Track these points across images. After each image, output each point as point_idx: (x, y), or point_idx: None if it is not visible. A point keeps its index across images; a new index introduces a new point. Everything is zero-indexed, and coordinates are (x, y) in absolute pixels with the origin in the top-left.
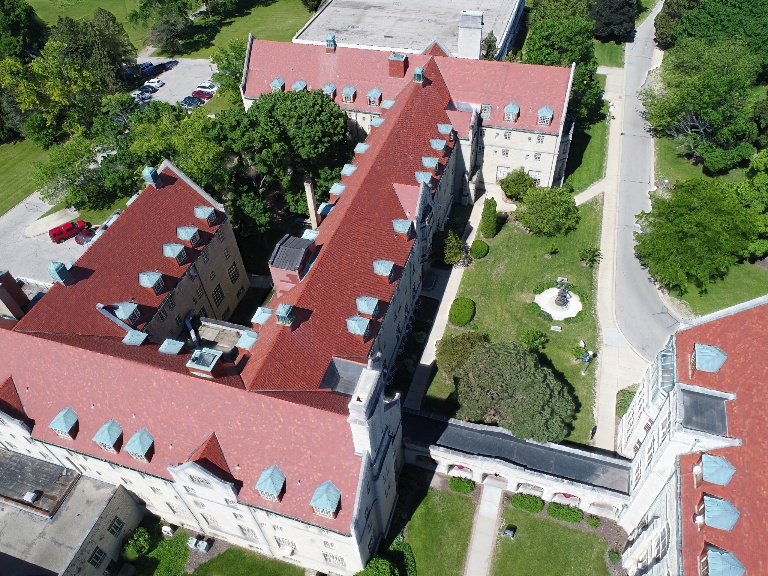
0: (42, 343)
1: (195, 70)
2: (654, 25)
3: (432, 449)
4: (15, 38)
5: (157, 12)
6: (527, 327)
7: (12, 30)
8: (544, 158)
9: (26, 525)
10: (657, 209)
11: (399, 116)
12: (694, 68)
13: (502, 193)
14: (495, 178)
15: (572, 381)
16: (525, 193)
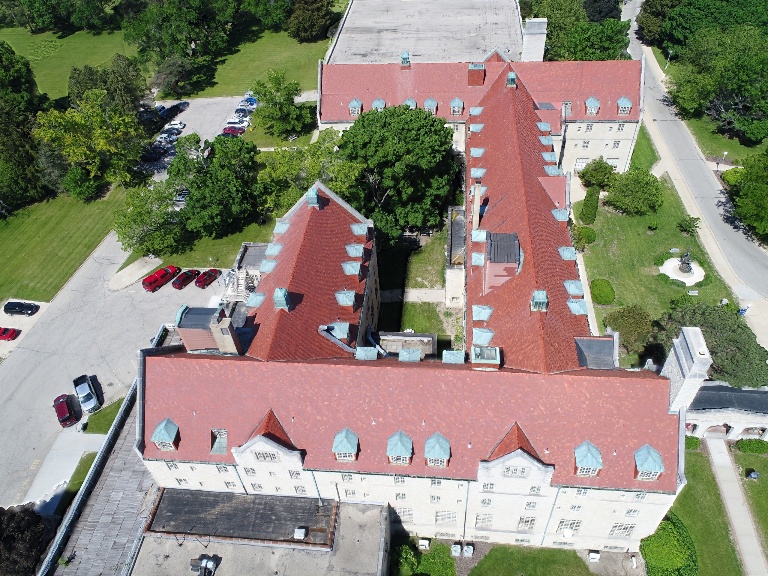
0: (305, 368)
1: (212, 108)
2: (640, 25)
3: None
4: (18, 94)
5: (159, 55)
6: (666, 296)
7: (12, 86)
8: (623, 145)
9: (308, 563)
10: (755, 173)
11: (515, 117)
12: (718, 54)
13: (579, 184)
14: (573, 170)
15: None
16: (610, 179)
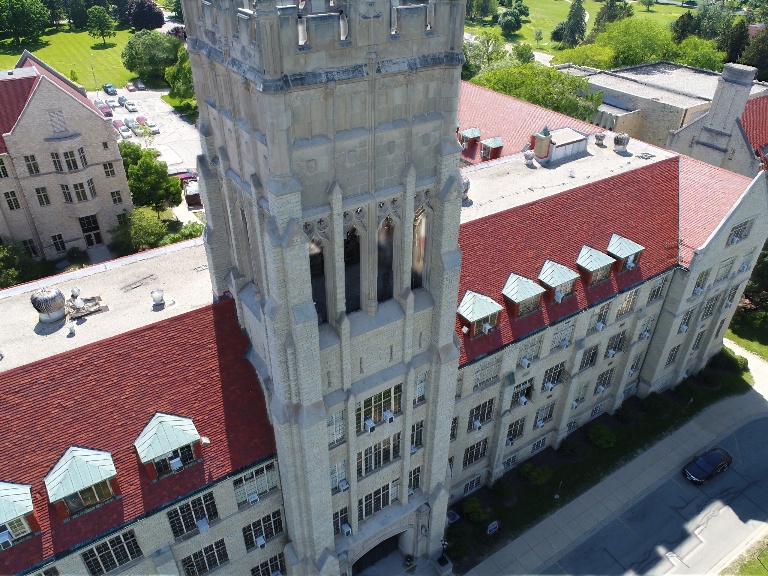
0: None
1: None
2: None
3: None
4: None
5: None
6: None
7: None
8: None
9: None
10: None
11: None
12: None
13: None
14: None
15: None
16: None
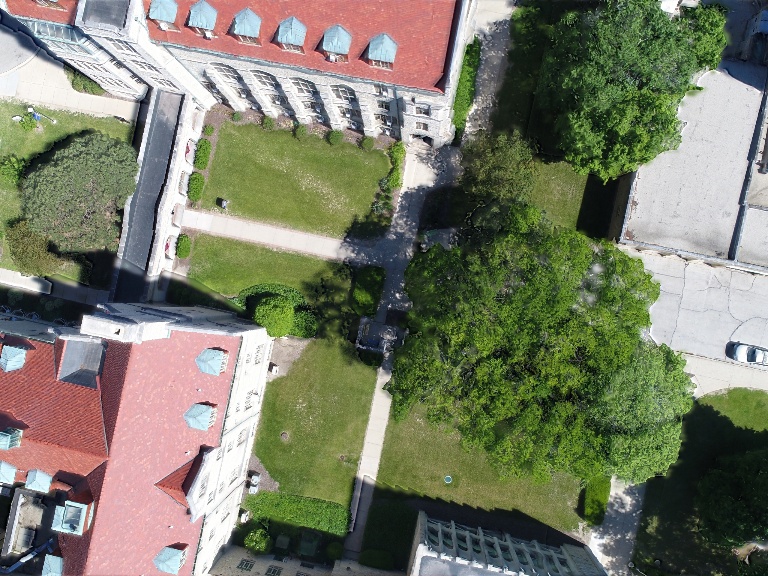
0: None
1: None
2: None
3: (152, 273)
4: None
5: None
6: None
7: None
8: None
9: None
10: None
11: None
12: None
13: None
14: None
15: (64, 134)
16: None
